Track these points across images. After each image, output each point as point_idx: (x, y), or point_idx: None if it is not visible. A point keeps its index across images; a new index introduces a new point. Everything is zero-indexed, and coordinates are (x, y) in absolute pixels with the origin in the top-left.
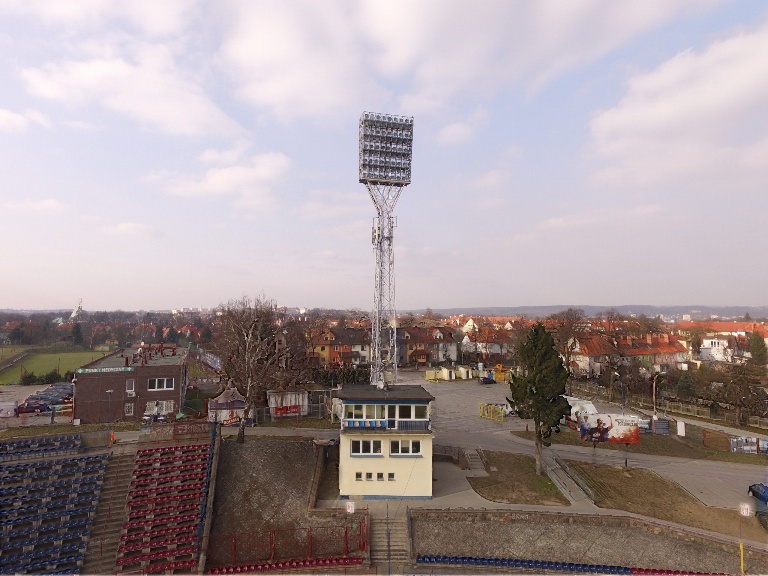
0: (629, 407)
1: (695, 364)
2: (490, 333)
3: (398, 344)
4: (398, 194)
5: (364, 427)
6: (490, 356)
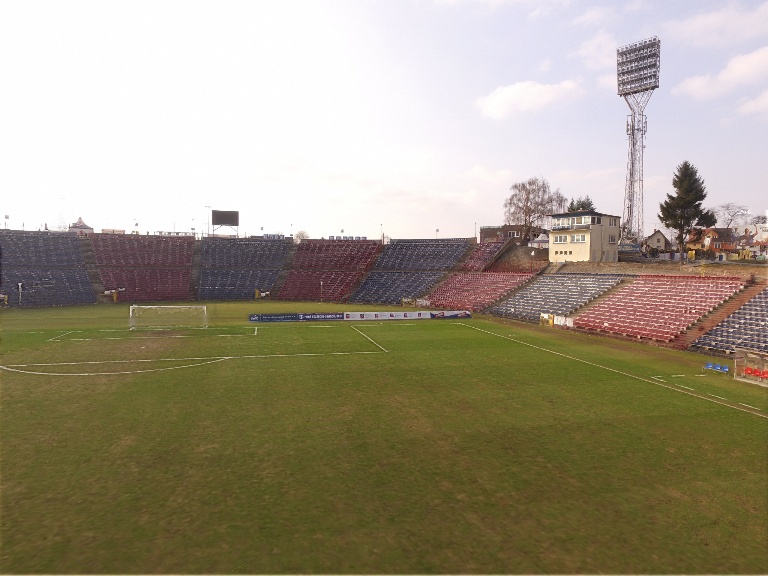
0: None
1: None
2: None
3: None
4: (645, 96)
5: (559, 229)
6: None
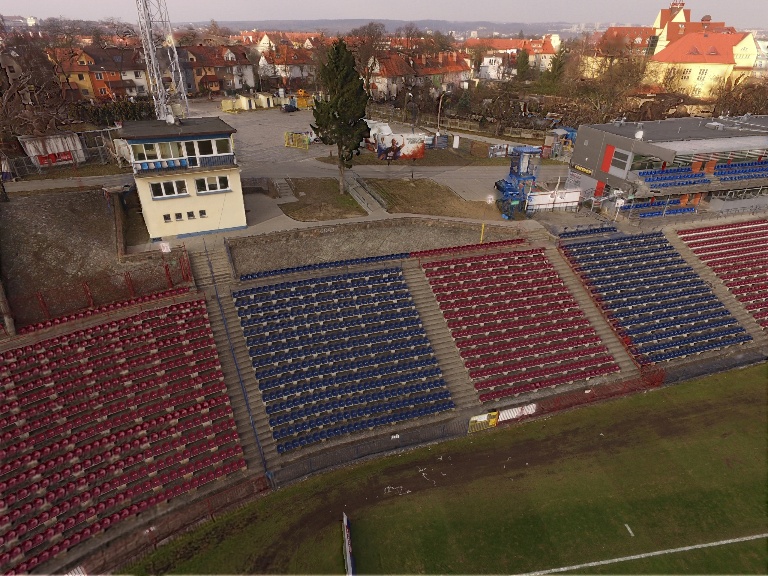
0: (418, 126)
1: (474, 82)
2: (289, 53)
3: (182, 68)
4: None
5: (161, 168)
6: (291, 80)
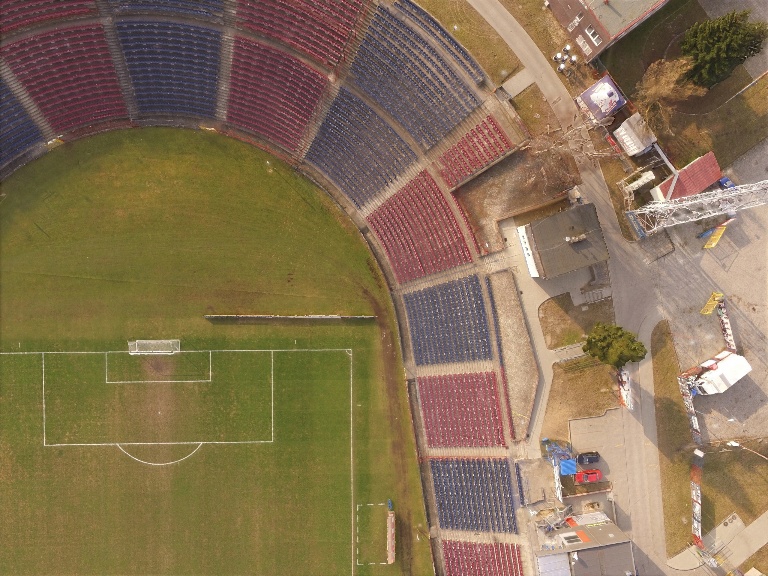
0: None
1: None
2: None
3: None
4: None
5: None
6: None
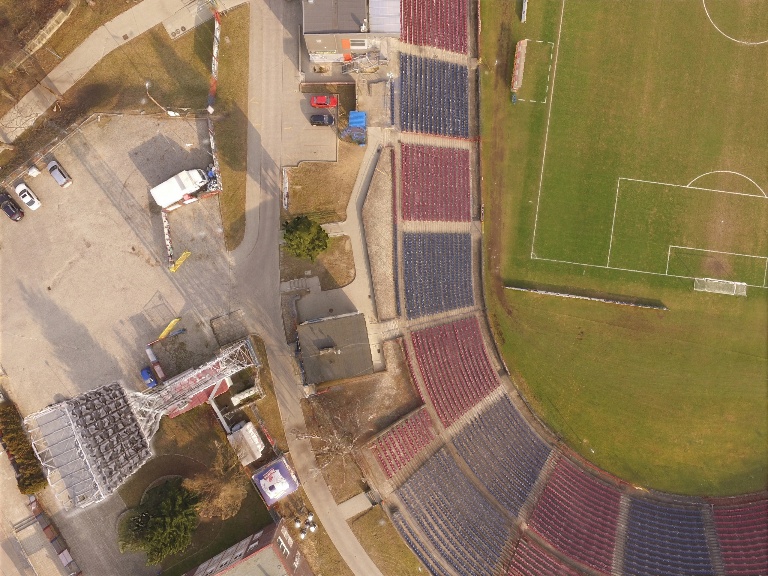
0: (102, 110)
1: None
2: None
3: None
4: None
5: None
6: None
